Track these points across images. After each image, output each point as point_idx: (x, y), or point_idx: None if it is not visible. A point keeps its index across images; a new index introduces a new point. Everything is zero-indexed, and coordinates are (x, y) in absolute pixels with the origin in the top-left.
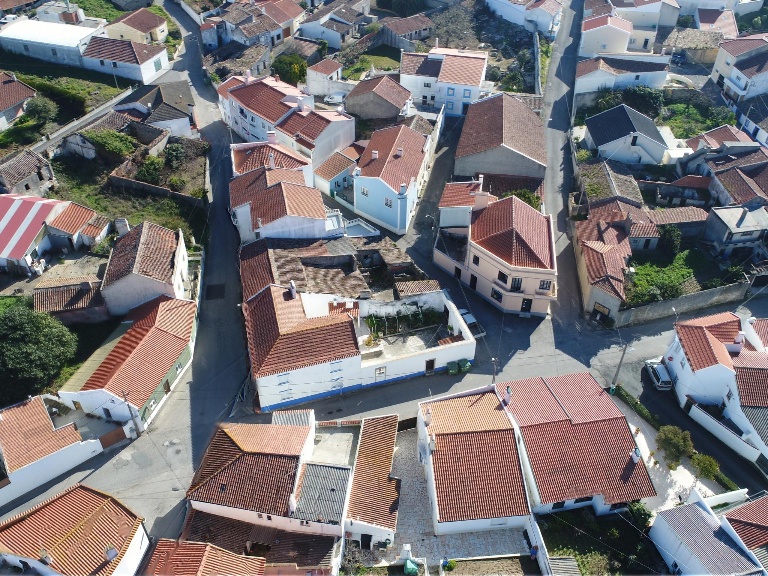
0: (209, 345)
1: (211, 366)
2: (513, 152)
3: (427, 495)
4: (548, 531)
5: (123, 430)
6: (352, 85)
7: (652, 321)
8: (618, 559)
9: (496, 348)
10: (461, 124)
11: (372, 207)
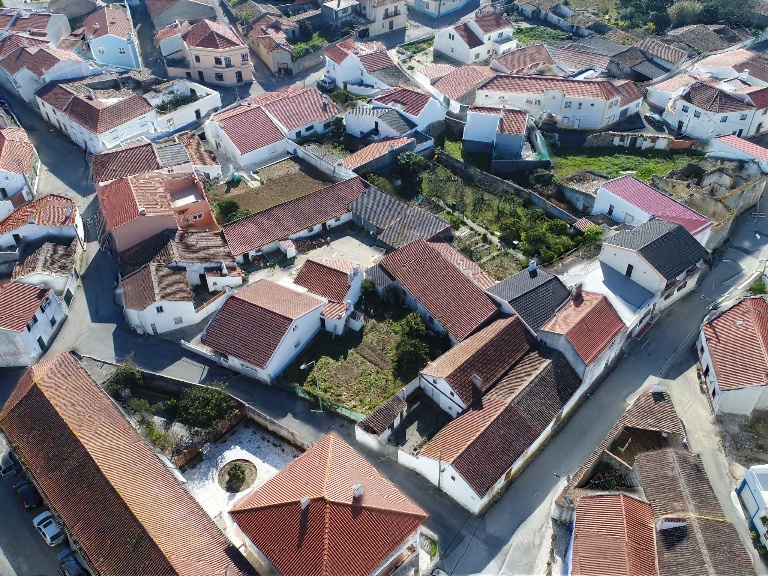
0: (46, 152)
1: (56, 159)
2: (190, 2)
3: (229, 158)
4: (298, 142)
5: (22, 194)
6: (46, 2)
7: (313, 67)
8: (336, 142)
9: (232, 98)
10: (144, 5)
11: (110, 60)
